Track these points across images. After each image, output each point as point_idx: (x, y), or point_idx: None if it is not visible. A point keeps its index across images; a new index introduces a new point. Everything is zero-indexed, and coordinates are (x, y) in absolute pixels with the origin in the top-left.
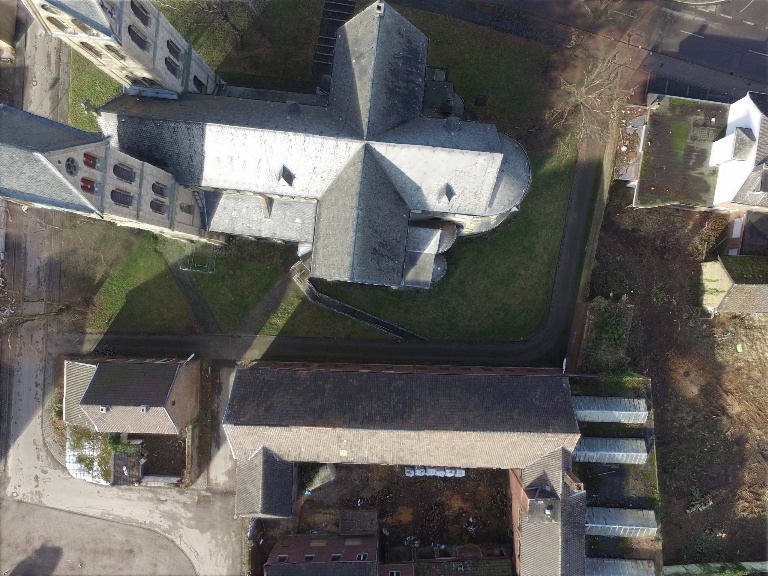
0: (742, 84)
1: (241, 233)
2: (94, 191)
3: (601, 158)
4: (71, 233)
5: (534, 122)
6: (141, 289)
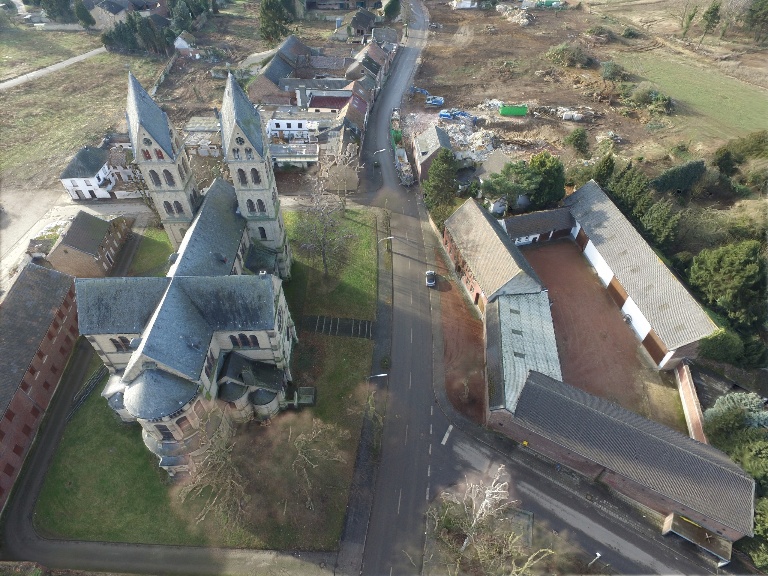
0: None
1: None
2: (148, 160)
3: None
4: None
5: (264, 490)
6: (166, 247)
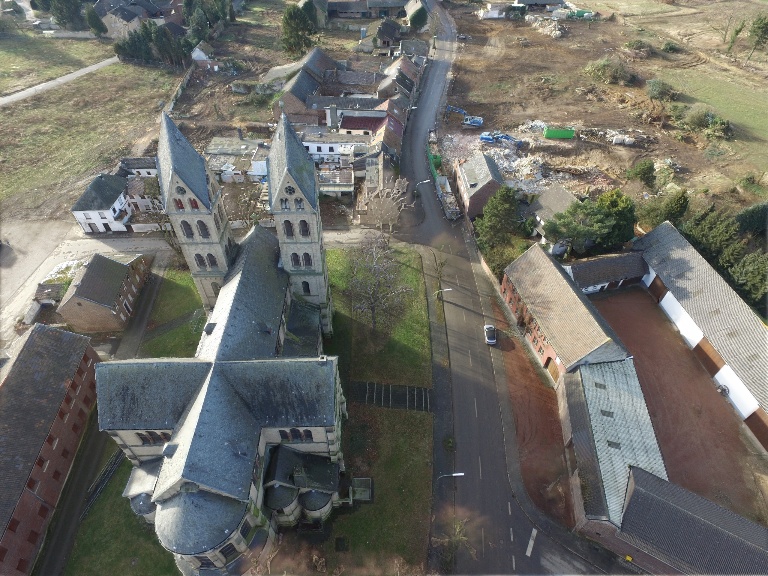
0: None
1: None
2: (180, 210)
3: None
4: None
5: None
6: (190, 292)
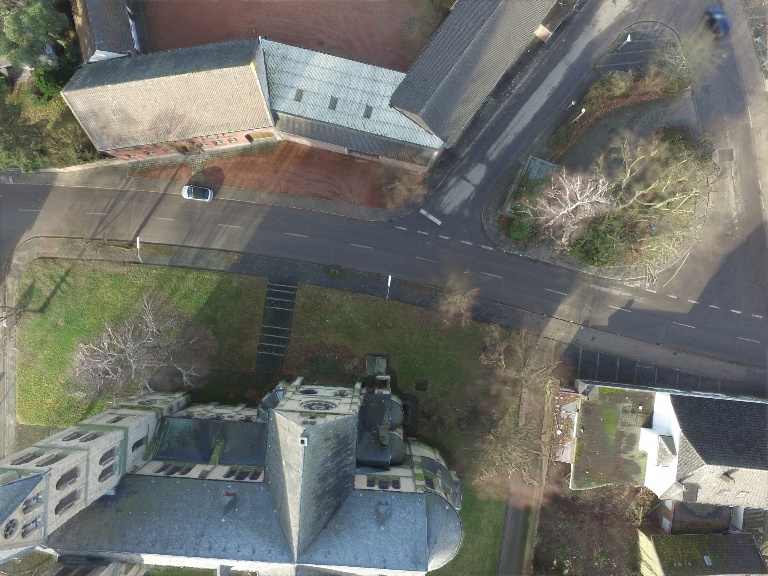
0: (668, 354)
1: None
2: None
3: (539, 431)
4: None
5: (474, 403)
6: None
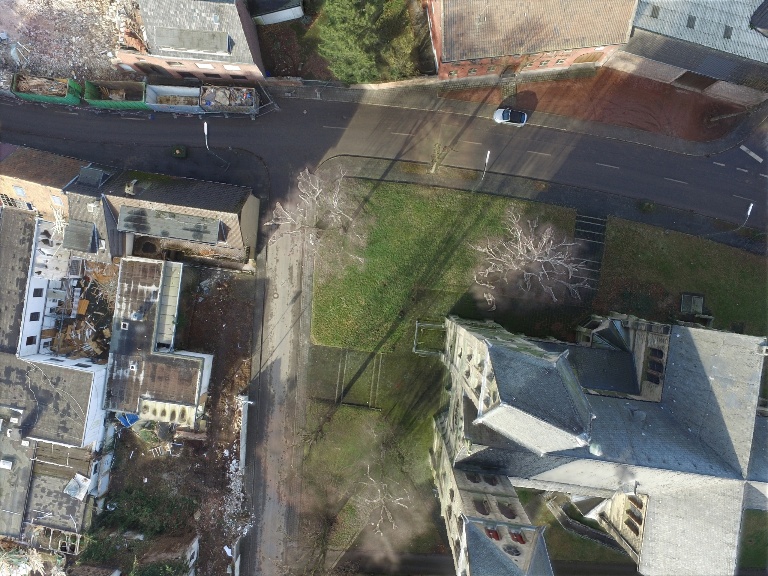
0: None
1: (524, 486)
2: None
3: None
4: (313, 449)
5: None
6: None
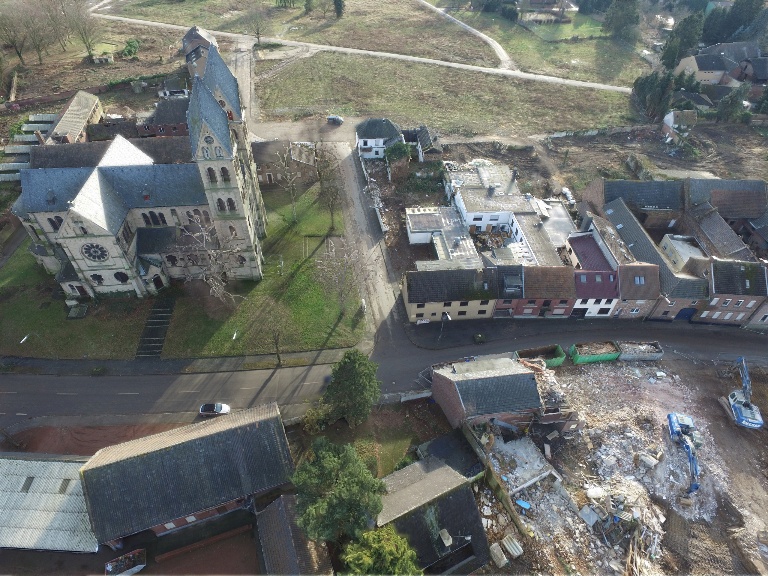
0: None
1: None
2: None
3: None
4: (337, 217)
5: (7, 301)
6: None
